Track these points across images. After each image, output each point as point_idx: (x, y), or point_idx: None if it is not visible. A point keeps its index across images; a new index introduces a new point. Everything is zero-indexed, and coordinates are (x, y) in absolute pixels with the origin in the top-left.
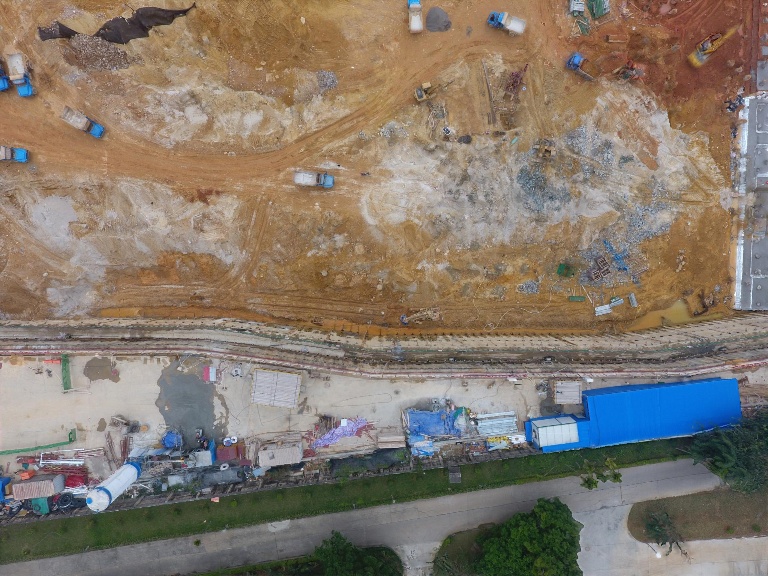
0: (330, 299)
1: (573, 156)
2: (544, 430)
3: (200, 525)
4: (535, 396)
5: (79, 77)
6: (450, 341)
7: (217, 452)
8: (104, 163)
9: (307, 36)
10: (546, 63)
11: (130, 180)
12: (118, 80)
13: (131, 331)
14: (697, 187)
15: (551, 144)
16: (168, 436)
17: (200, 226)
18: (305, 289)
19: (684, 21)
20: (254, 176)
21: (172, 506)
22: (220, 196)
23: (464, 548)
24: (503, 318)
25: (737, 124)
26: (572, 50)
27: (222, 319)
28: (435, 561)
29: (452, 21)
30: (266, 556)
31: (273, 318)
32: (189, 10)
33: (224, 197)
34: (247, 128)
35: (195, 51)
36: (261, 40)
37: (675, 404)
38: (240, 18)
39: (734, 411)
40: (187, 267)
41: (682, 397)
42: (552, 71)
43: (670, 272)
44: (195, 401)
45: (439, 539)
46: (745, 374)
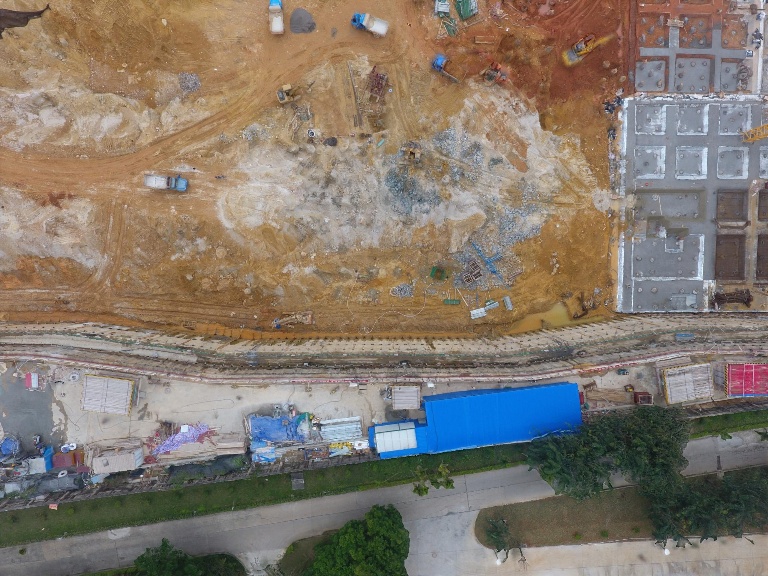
0: (202, 303)
1: (442, 158)
2: (381, 436)
3: (38, 533)
4: (380, 401)
5: None
6: (314, 345)
7: (53, 459)
8: None
9: (169, 38)
10: (413, 65)
11: None
12: None
13: None
14: (569, 189)
15: (416, 146)
16: (5, 443)
17: (54, 230)
18: (174, 293)
19: (561, 22)
20: (108, 179)
21: (9, 514)
22: (73, 200)
23: (308, 555)
24: (378, 322)
25: (614, 125)
26: (439, 51)
27: (84, 324)
28: (266, 569)
29: (316, 22)
30: (107, 564)
31: (142, 322)
32: (43, 12)
33: (77, 201)
34: (102, 131)
35: (54, 53)
36: (122, 42)
37: (514, 409)
38: (97, 20)
39: (574, 416)
40: (47, 271)
41: (521, 402)
42: (419, 73)
43: (546, 275)
44: (33, 407)
45: (283, 546)
46: (593, 378)
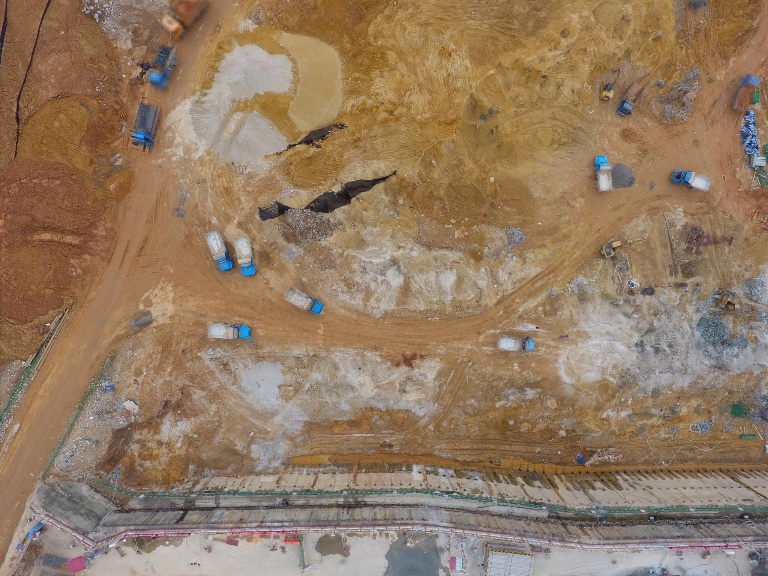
0: (509, 440)
1: (751, 303)
2: None
3: None
4: (747, 564)
5: (297, 254)
6: (638, 490)
7: None
8: (320, 336)
9: (496, 194)
10: (726, 215)
11: (343, 350)
12: (328, 251)
13: (344, 495)
14: None
15: (734, 296)
16: None
17: (403, 388)
18: None
19: None
20: (456, 339)
21: None
22: (424, 360)
23: None
24: (676, 456)
25: None
26: (752, 202)
27: (416, 470)
28: None
29: (636, 177)
30: None
31: (456, 461)
32: (389, 177)
33: (428, 361)
34: (447, 291)
35: (390, 212)
36: (451, 199)
37: None
38: (436, 182)
39: None
40: (382, 420)
41: None
42: (732, 223)
43: None
44: (421, 574)
45: None
46: None
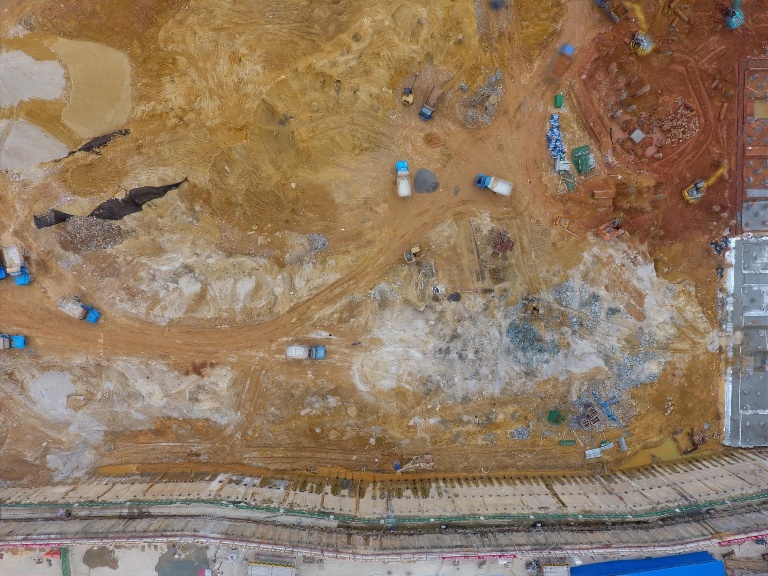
0: (324, 448)
1: (561, 309)
2: None
3: None
4: (525, 573)
5: (74, 262)
6: (442, 498)
7: None
8: (100, 345)
9: (298, 200)
10: (533, 220)
11: (126, 359)
12: (113, 259)
13: (129, 506)
14: (684, 335)
15: (539, 302)
16: None
17: (195, 396)
18: (300, 442)
19: (669, 165)
20: (247, 347)
21: None
22: (214, 368)
23: None
24: (495, 462)
25: None
26: (558, 207)
27: (218, 479)
28: None
29: (440, 182)
30: None
31: (269, 470)
32: (181, 183)
33: (218, 369)
34: (240, 299)
35: (188, 219)
36: (252, 205)
37: None
38: (231, 188)
39: None
40: (183, 429)
41: None
42: (539, 228)
43: (659, 415)
44: None
45: None
46: (731, 547)
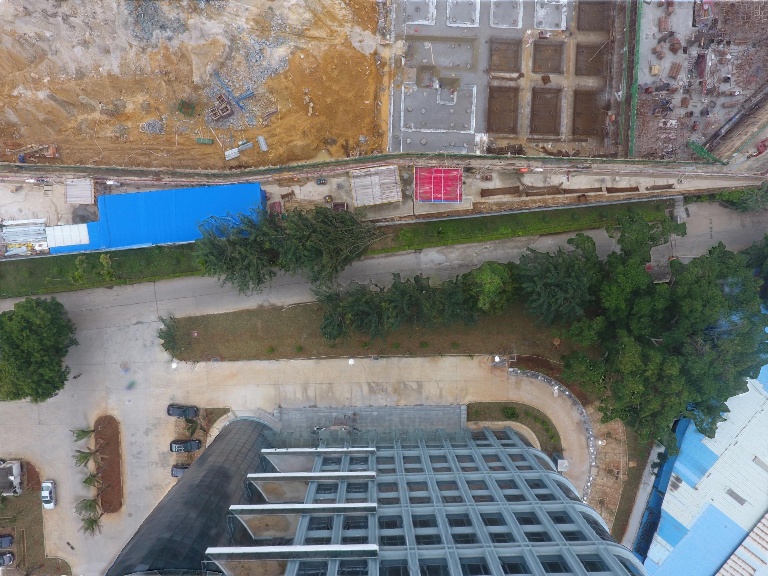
0: None
1: None
2: (51, 230)
3: None
4: None
5: None
6: None
7: None
8: None
9: None
10: None
11: None
12: None
13: None
14: (321, 23)
15: None
16: None
17: None
18: None
19: None
20: None
21: None
22: None
23: None
24: (128, 160)
25: None
26: None
27: None
28: None
29: None
30: None
31: None
32: None
33: None
34: None
35: None
36: None
37: (192, 207)
38: None
39: None
40: None
41: (199, 200)
42: None
43: (302, 116)
44: None
45: None
46: (292, 188)
